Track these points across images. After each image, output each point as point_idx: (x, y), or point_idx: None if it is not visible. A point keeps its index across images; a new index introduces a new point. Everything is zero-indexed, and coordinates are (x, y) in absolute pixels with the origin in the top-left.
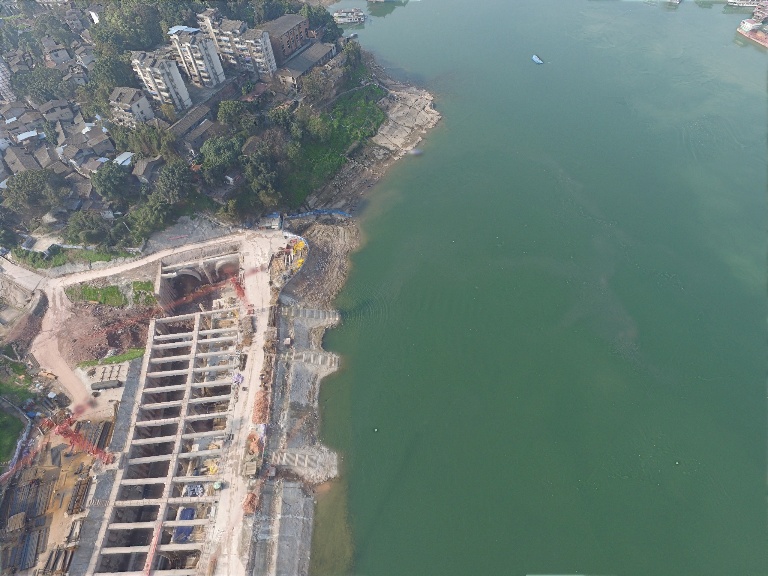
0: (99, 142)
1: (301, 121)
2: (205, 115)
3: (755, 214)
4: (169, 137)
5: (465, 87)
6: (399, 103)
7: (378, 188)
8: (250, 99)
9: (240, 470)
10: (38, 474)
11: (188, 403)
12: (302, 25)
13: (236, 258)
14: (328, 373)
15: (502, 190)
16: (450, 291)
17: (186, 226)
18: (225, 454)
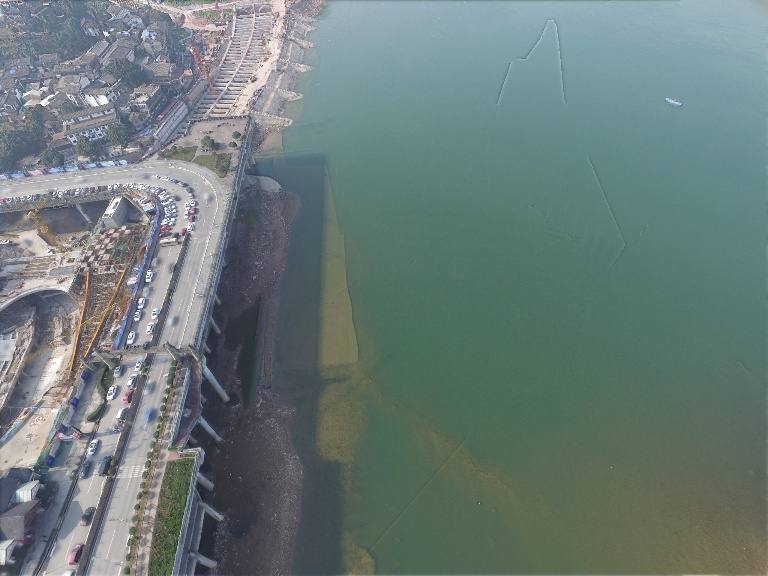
0: None
1: None
2: None
3: None
4: None
5: None
6: None
7: None
8: None
9: None
10: None
11: (254, 29)
12: None
13: (268, 7)
14: (310, 30)
15: None
16: (366, 12)
17: None
18: (270, 36)
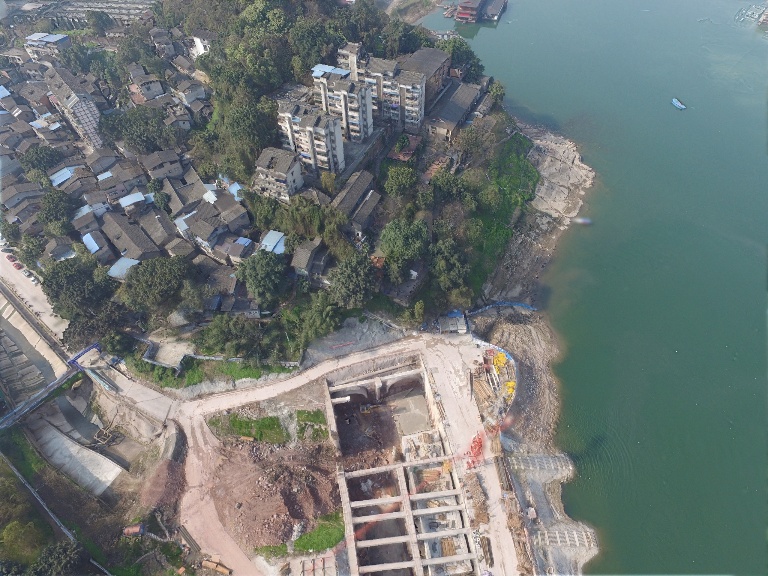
0: (236, 217)
1: None
2: (369, 184)
3: None
4: (340, 219)
5: (607, 135)
6: (548, 156)
7: (554, 269)
8: (403, 157)
9: None
10: None
11: None
12: (446, 62)
13: None
14: (588, 558)
15: (707, 278)
16: (699, 426)
17: (354, 331)
18: None
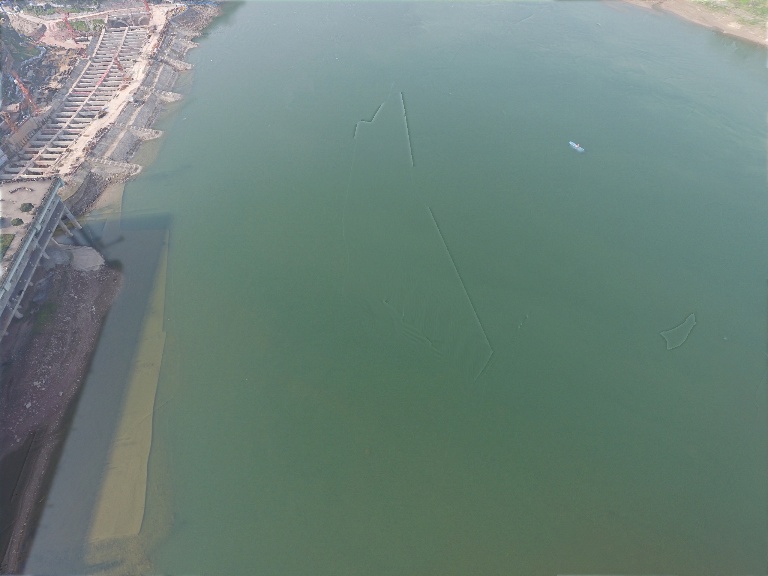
0: None
1: None
2: None
3: (427, 1)
4: None
5: None
6: None
7: None
8: None
9: (145, 58)
10: (52, 59)
11: (122, 47)
12: None
13: None
14: (192, 47)
15: None
16: (261, 26)
17: None
18: (138, 56)
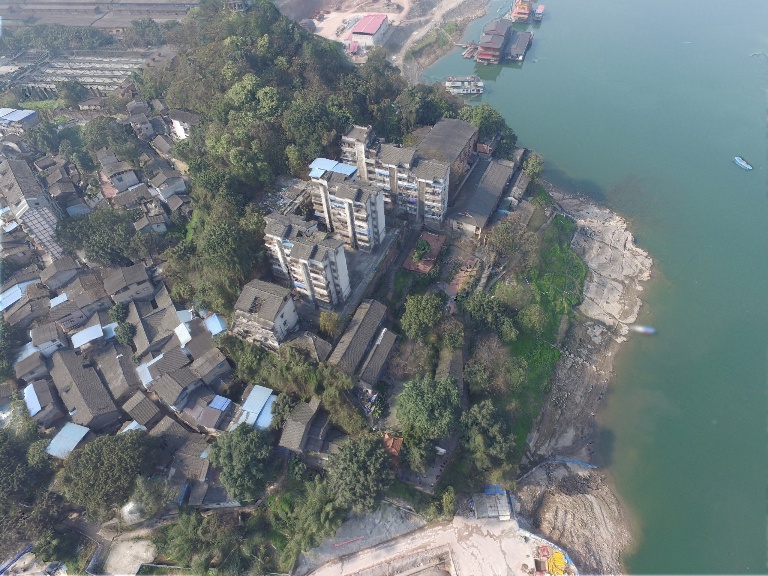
0: (212, 368)
1: (502, 303)
2: (381, 320)
3: None
4: (343, 384)
5: (661, 205)
6: (595, 241)
7: (613, 402)
8: (423, 267)
9: None
10: None
11: None
12: (472, 138)
13: (441, 571)
14: None
15: None
16: None
17: (363, 523)
18: None
